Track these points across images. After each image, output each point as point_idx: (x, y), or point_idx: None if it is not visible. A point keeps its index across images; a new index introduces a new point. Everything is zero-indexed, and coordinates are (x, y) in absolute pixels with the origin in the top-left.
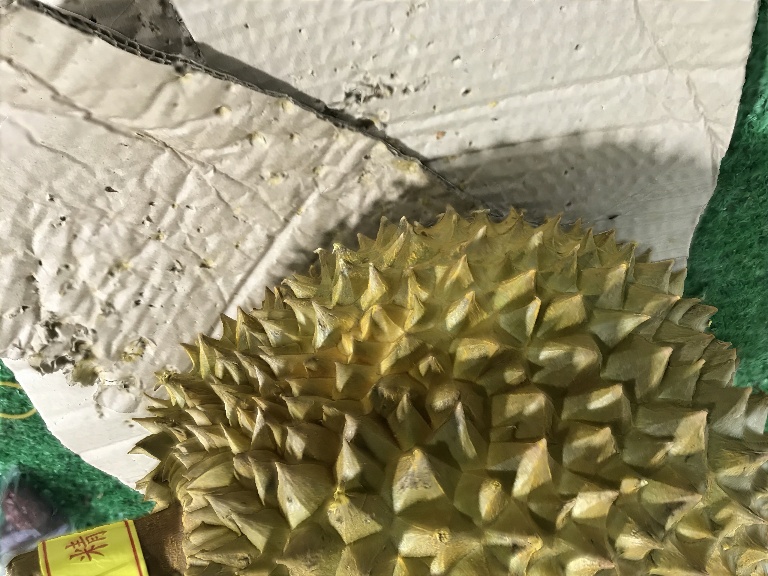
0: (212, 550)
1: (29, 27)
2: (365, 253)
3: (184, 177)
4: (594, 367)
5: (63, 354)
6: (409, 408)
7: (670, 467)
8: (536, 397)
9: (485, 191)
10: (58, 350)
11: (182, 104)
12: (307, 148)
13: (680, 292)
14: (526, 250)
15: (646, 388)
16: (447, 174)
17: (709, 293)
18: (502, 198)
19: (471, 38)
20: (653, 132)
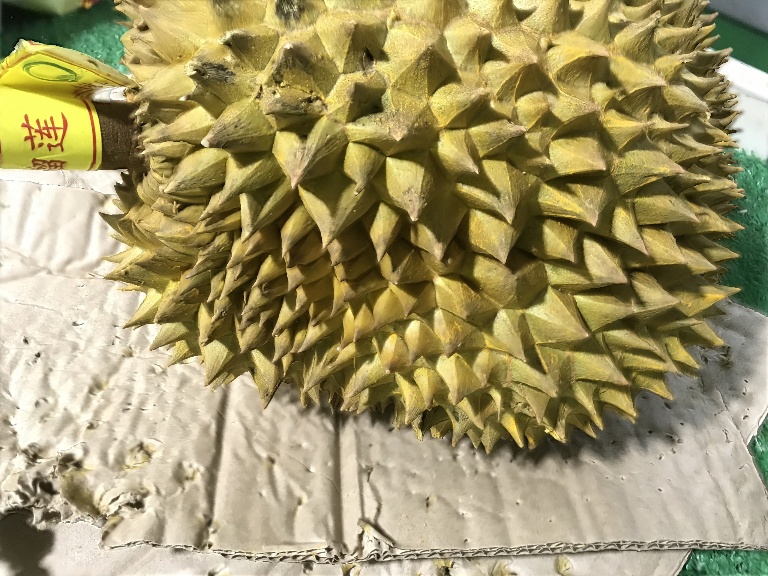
0: None
1: (2, 194)
2: None
3: (137, 299)
4: None
5: (47, 473)
6: None
7: None
8: None
9: None
10: (41, 466)
11: None
12: None
13: None
14: None
15: None
16: None
17: None
18: None
19: None
20: None
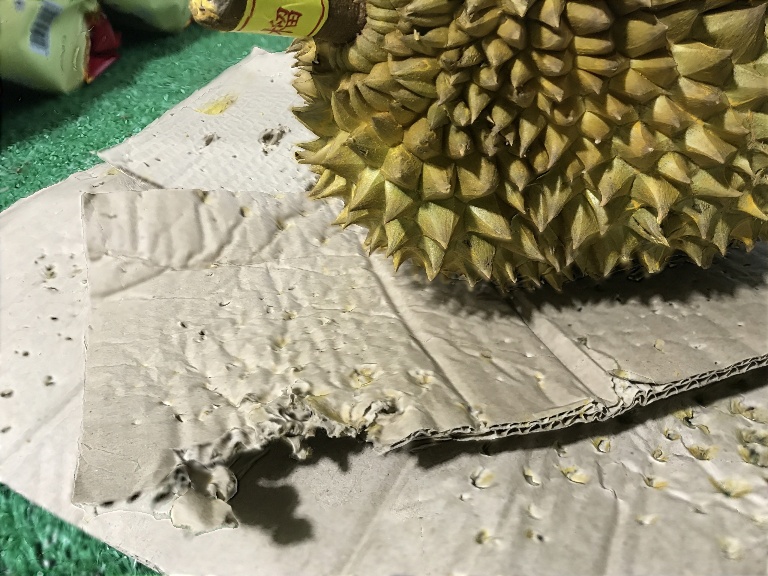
0: None
1: (105, 206)
2: None
3: None
4: None
5: (286, 404)
6: None
7: None
8: None
9: None
10: None
11: (218, 216)
12: None
13: None
14: None
15: None
16: None
17: None
18: None
19: None
20: None
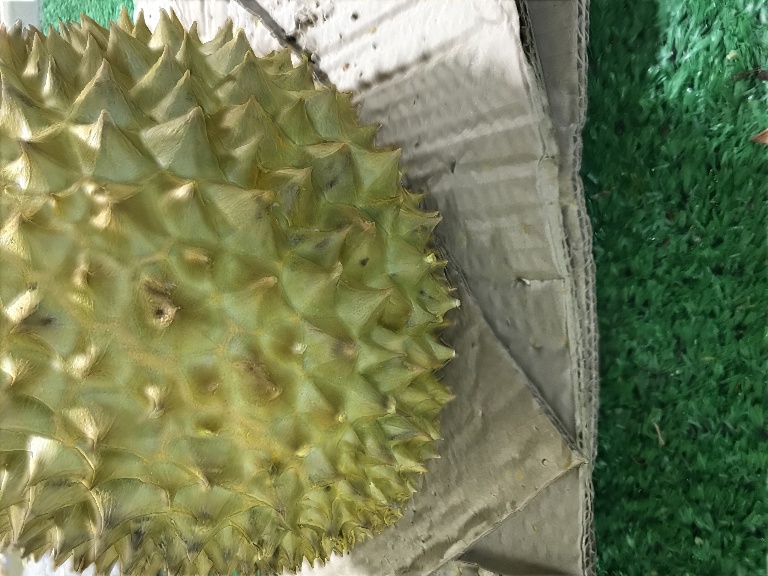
0: None
1: None
2: None
3: None
4: (120, 53)
5: None
6: None
7: (60, 112)
8: None
9: None
10: None
11: None
12: None
13: (376, 168)
14: None
15: None
16: None
17: (668, 430)
18: (376, 137)
19: None
20: None
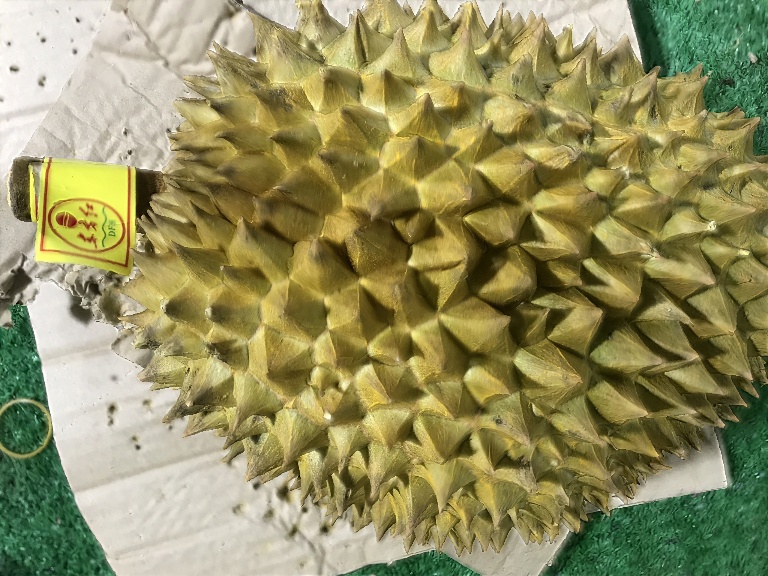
0: None
1: None
2: None
3: None
4: None
5: (97, 278)
6: None
7: None
8: None
9: None
10: (94, 271)
11: (230, 42)
12: None
13: None
14: None
15: None
16: None
17: None
18: None
19: None
20: None
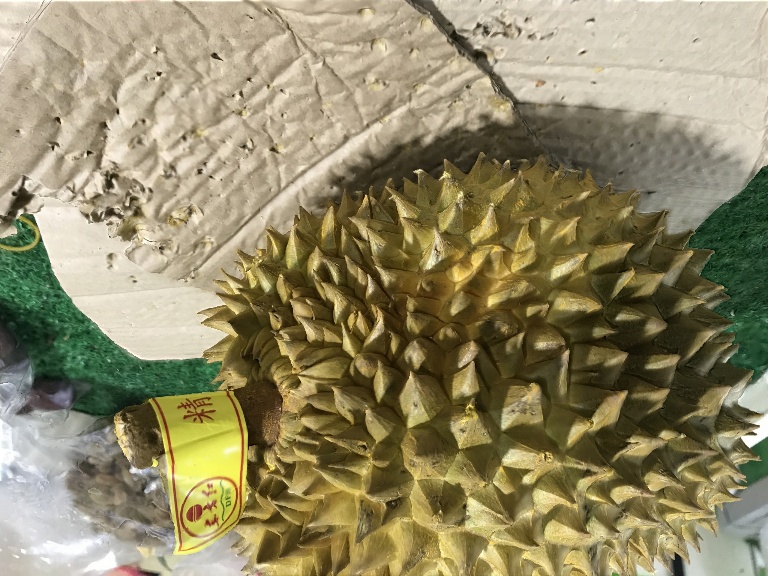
0: (338, 435)
1: None
2: (469, 187)
3: (291, 62)
4: (657, 335)
5: (114, 206)
6: (521, 344)
7: (690, 424)
8: (620, 354)
9: (555, 143)
10: (112, 202)
11: None
12: (421, 65)
13: None
14: (615, 219)
15: (685, 357)
16: (529, 120)
17: None
18: (567, 153)
19: (613, 6)
20: (719, 130)
